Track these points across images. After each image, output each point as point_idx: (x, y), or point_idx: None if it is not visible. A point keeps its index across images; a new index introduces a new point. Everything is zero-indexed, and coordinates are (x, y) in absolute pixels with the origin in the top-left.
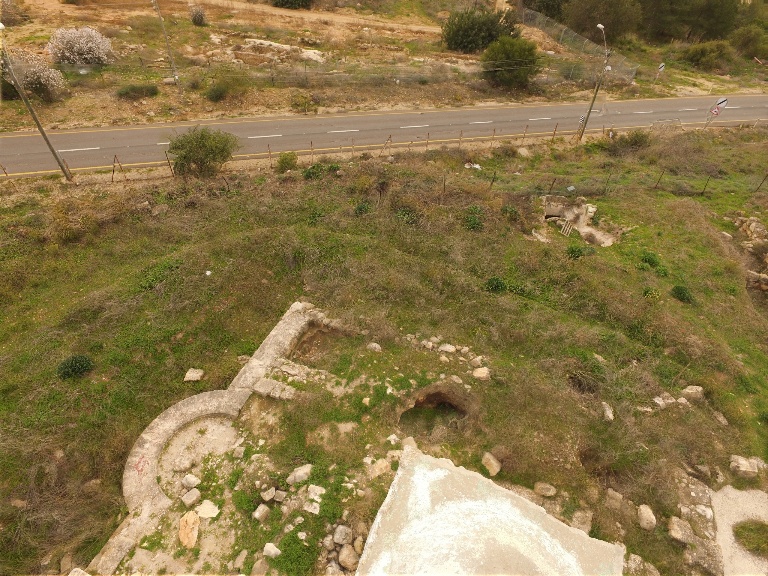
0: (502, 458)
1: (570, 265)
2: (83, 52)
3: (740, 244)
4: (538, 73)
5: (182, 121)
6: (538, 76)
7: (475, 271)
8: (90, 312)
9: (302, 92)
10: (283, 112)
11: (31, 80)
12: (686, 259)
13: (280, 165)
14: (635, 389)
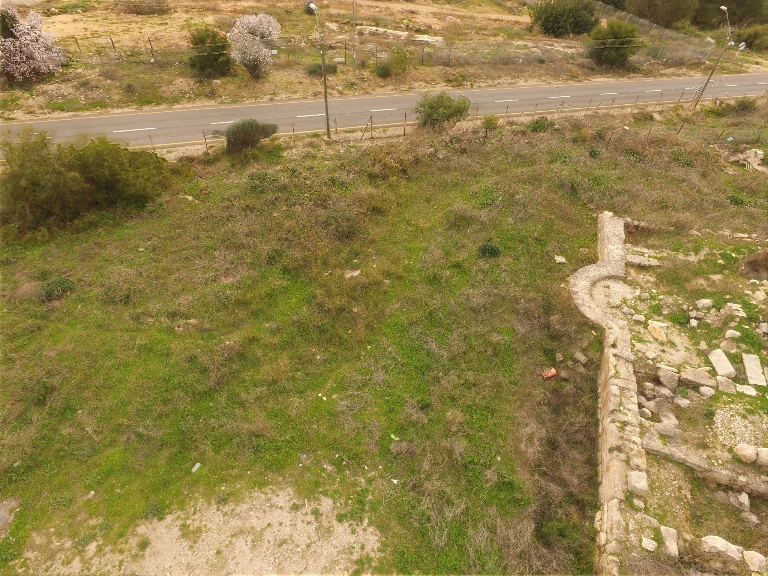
0: None
1: None
2: (263, 36)
3: None
4: None
5: (370, 94)
6: None
7: None
8: (463, 219)
9: (449, 70)
10: (441, 87)
11: (253, 58)
12: None
13: (482, 126)
14: None
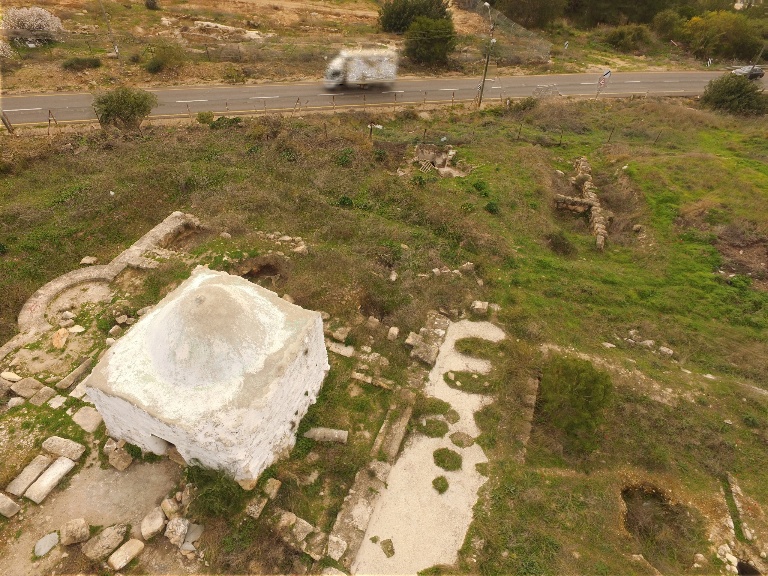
0: (295, 296)
1: (410, 189)
2: None
3: (568, 179)
4: (454, 50)
5: None
6: (462, 55)
7: (332, 193)
8: (10, 217)
9: (235, 66)
10: (215, 83)
11: None
12: (509, 185)
13: None
14: (419, 262)
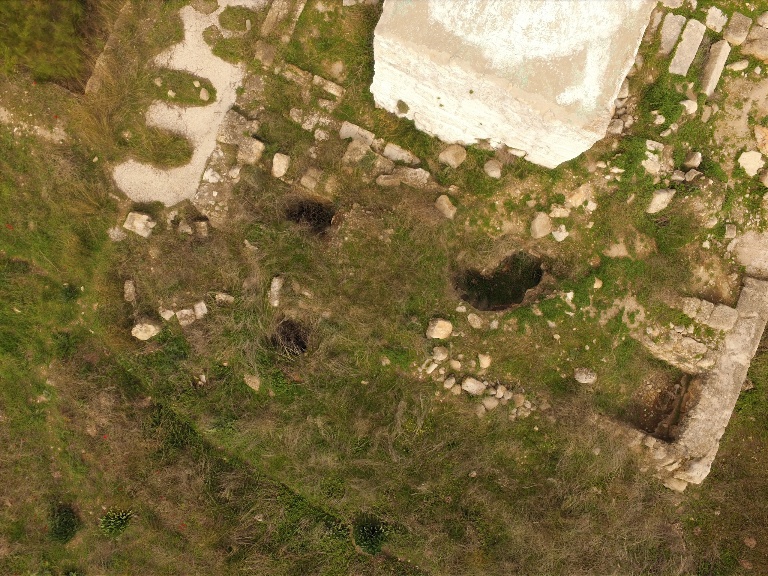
0: None
1: None
2: None
3: None
4: None
5: None
6: None
7: (399, 574)
8: None
9: None
10: None
11: None
12: None
13: None
14: (228, 322)
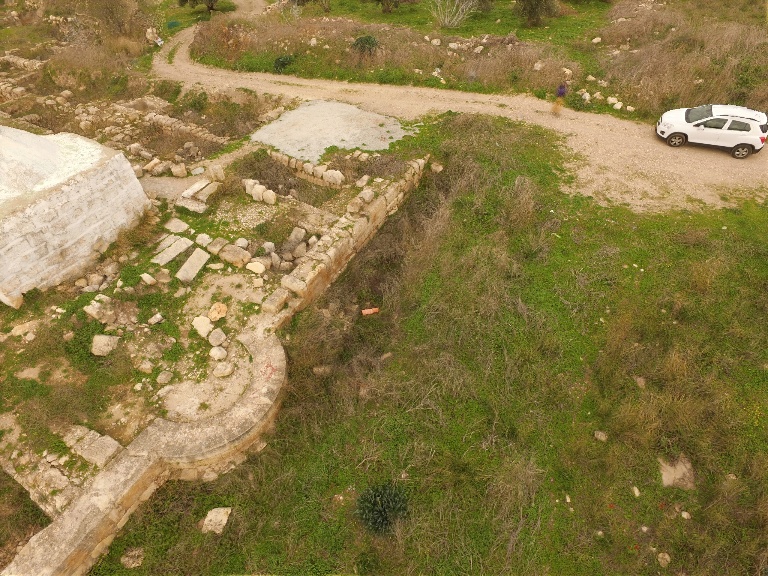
0: None
1: None
2: None
3: None
4: None
5: None
6: None
7: None
8: None
9: None
10: None
11: None
12: None
13: None
14: None
